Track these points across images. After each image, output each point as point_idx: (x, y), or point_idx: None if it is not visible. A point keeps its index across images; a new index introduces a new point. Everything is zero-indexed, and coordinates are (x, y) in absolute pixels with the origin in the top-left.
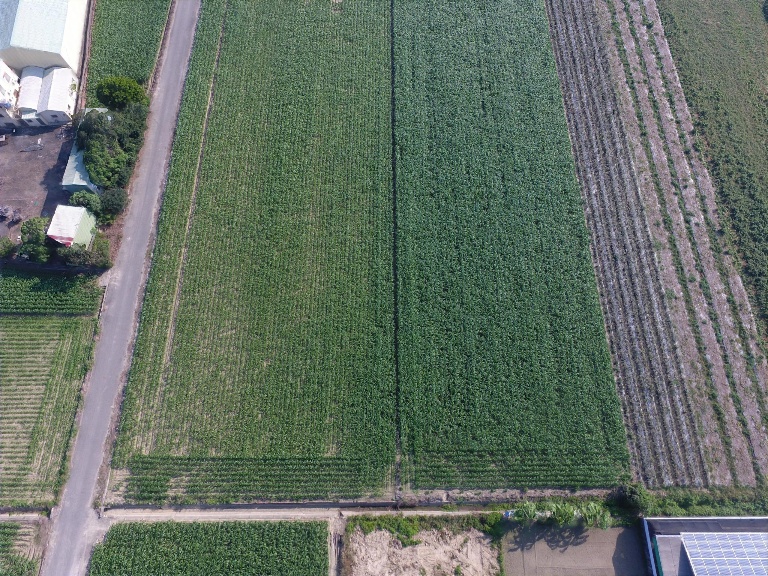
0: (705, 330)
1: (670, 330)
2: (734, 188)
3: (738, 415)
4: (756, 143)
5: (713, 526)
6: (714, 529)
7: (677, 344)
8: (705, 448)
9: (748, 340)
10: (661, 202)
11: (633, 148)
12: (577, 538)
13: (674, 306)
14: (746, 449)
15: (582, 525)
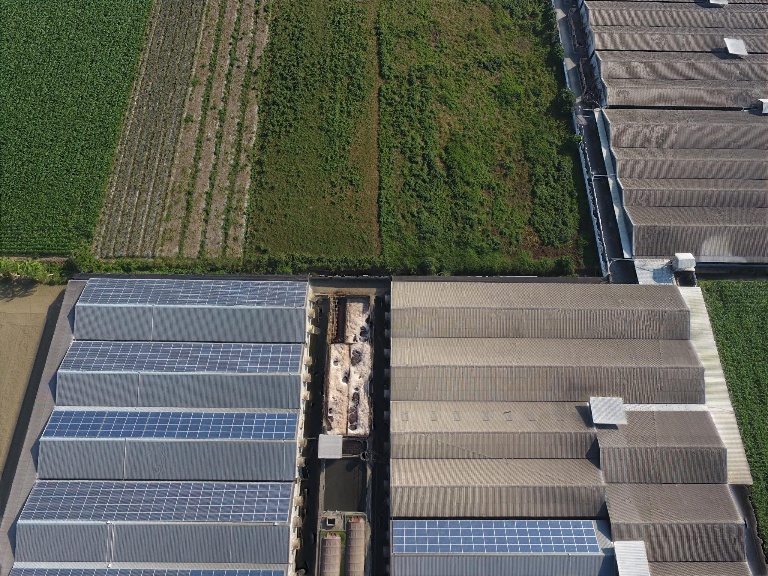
0: (207, 145)
1: (177, 145)
2: (284, 40)
3: (206, 207)
4: (322, 6)
5: (124, 276)
6: (122, 277)
7: (178, 155)
8: (165, 230)
9: (241, 153)
10: (214, 50)
11: (209, 9)
12: (26, 292)
13: (188, 127)
14: (200, 231)
15: (33, 283)
